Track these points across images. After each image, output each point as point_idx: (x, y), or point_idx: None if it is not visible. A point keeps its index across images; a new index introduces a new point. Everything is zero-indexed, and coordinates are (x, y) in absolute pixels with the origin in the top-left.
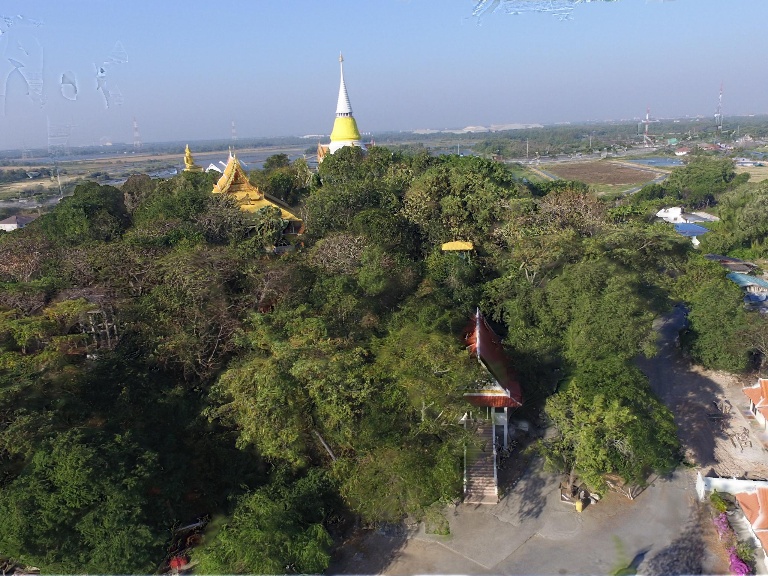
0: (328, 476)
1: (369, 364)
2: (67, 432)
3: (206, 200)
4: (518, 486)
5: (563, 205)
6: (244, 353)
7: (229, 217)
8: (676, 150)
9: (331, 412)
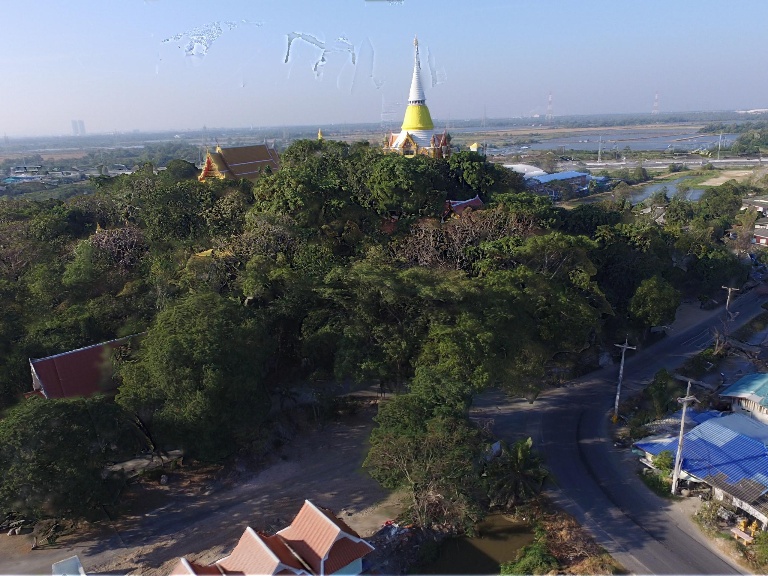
0: None
1: None
2: None
3: None
4: None
5: (477, 226)
6: None
7: (113, 200)
8: None
9: None
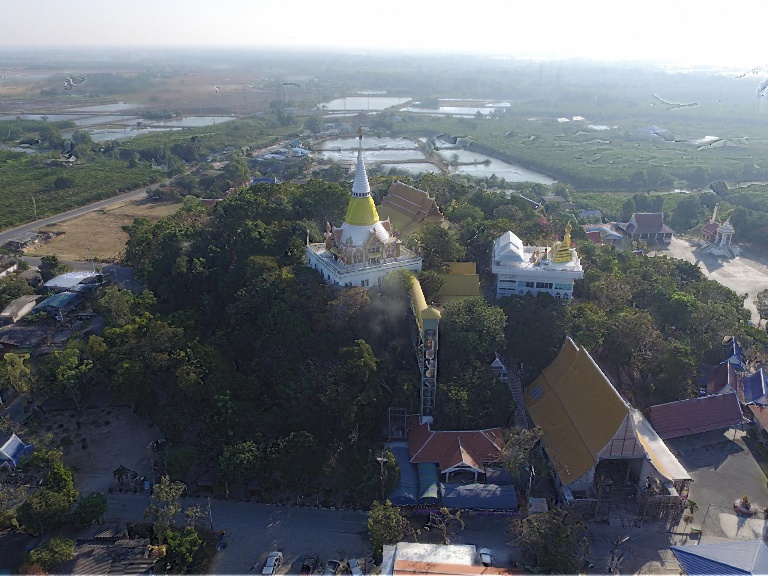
0: None
1: None
2: None
3: None
4: None
5: None
6: None
7: None
8: None
9: None
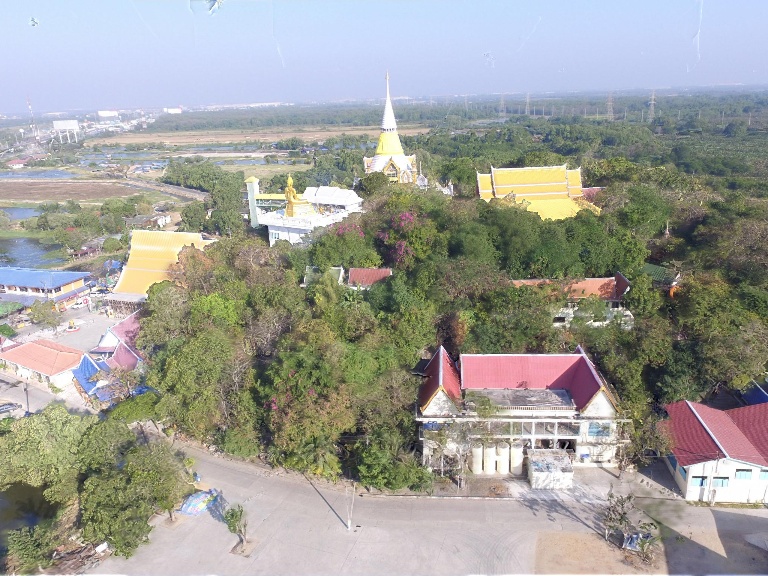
0: None
1: None
2: None
3: None
4: None
5: None
6: None
7: None
8: (8, 163)
9: None
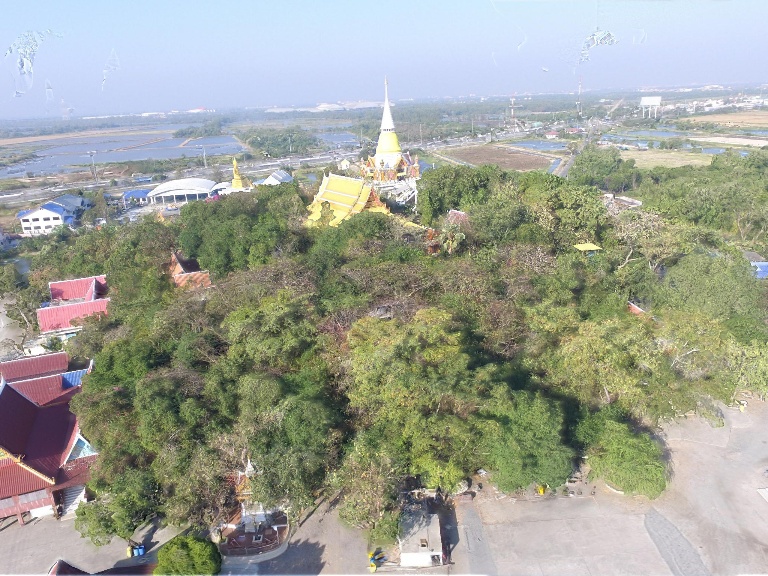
0: (617, 408)
1: (658, 333)
2: (521, 393)
3: (386, 220)
4: (698, 403)
5: None
6: (533, 335)
7: (421, 234)
8: (546, 134)
9: (646, 364)
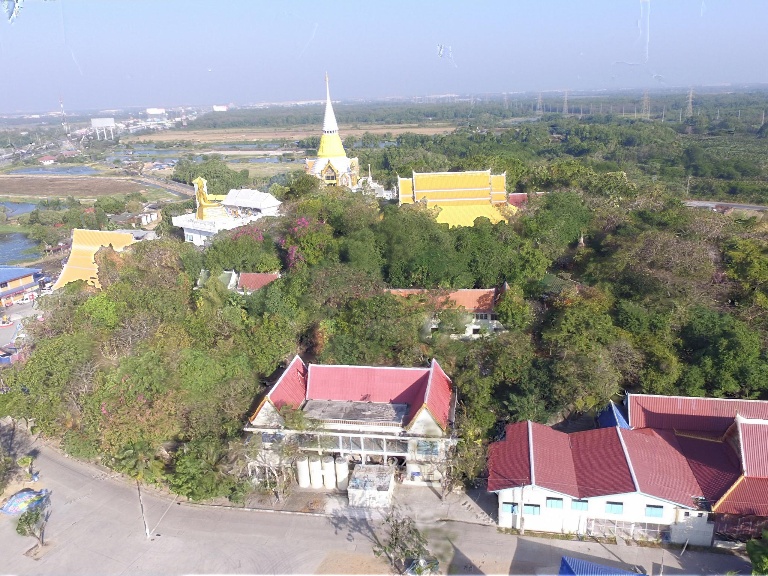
0: None
1: None
2: None
3: None
4: None
5: None
6: None
7: None
8: (40, 159)
9: None
